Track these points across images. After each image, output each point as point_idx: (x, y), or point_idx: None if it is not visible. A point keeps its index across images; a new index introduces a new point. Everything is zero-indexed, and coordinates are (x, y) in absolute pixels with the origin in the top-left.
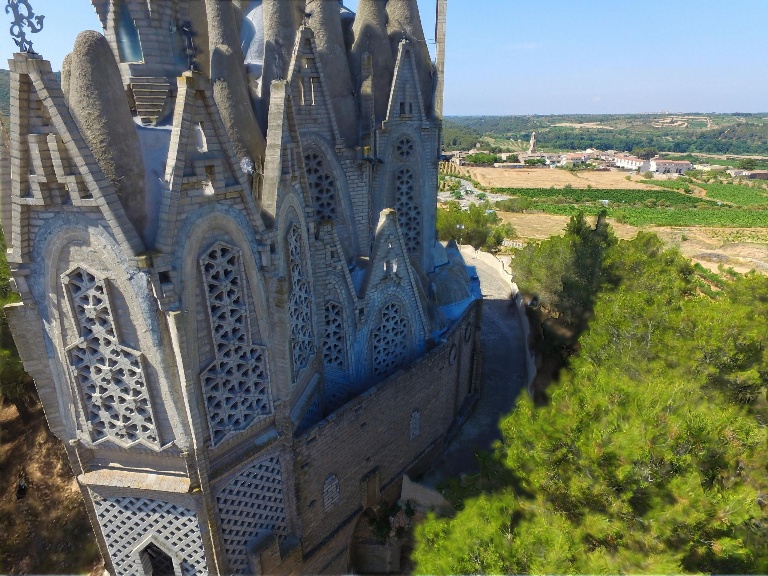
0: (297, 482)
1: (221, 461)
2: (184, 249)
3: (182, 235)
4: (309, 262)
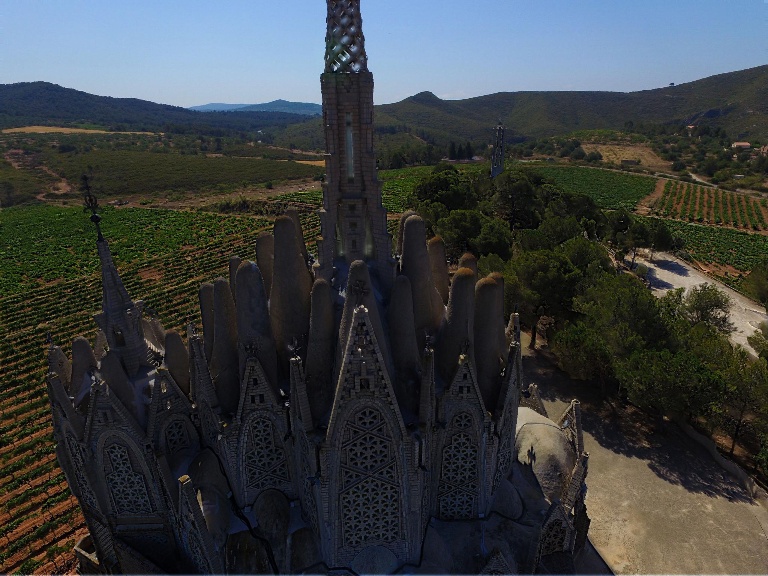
0: (117, 557)
1: None
2: None
3: (61, 423)
4: (145, 466)
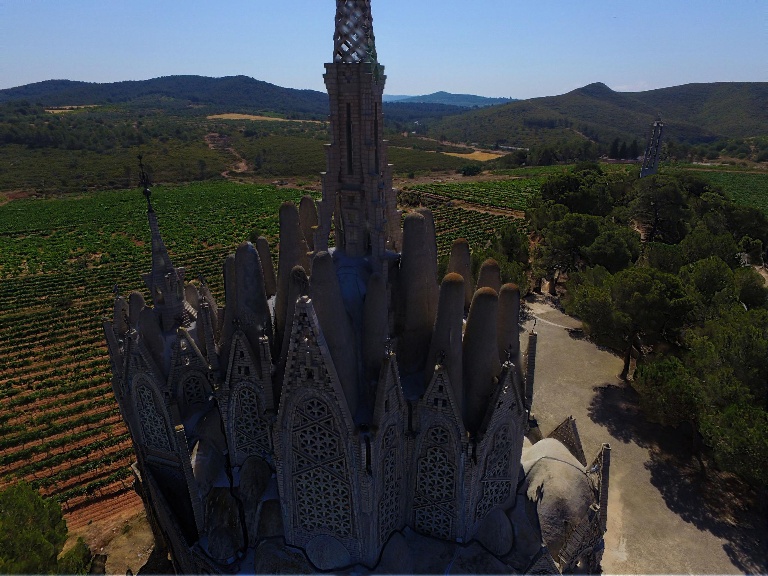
0: None
1: None
2: None
3: None
4: (165, 410)
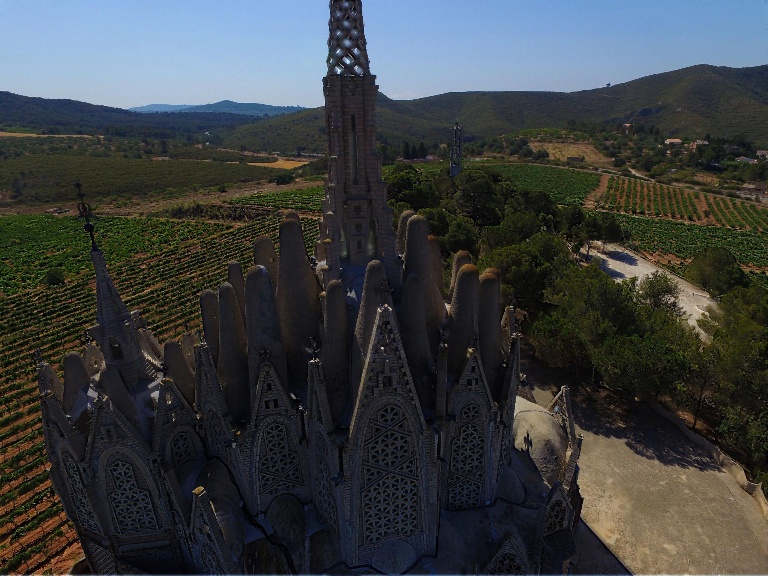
0: None
1: (90, 533)
2: (57, 448)
3: None
4: (151, 482)
